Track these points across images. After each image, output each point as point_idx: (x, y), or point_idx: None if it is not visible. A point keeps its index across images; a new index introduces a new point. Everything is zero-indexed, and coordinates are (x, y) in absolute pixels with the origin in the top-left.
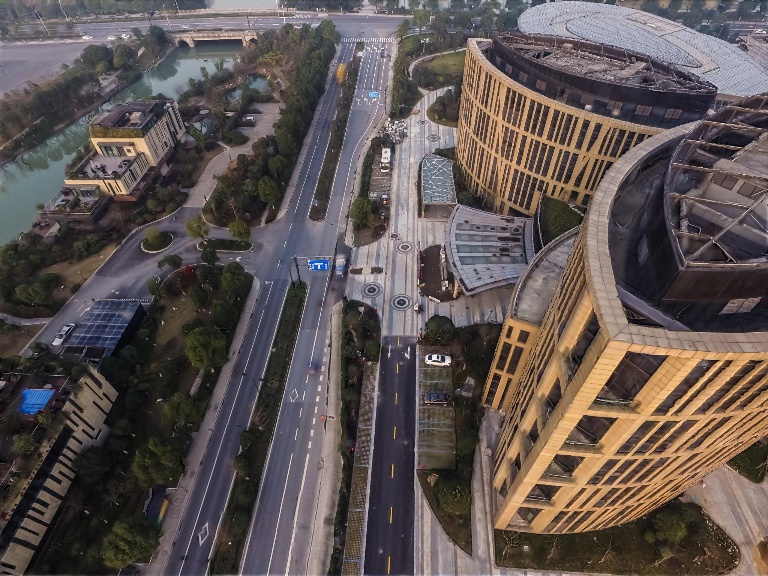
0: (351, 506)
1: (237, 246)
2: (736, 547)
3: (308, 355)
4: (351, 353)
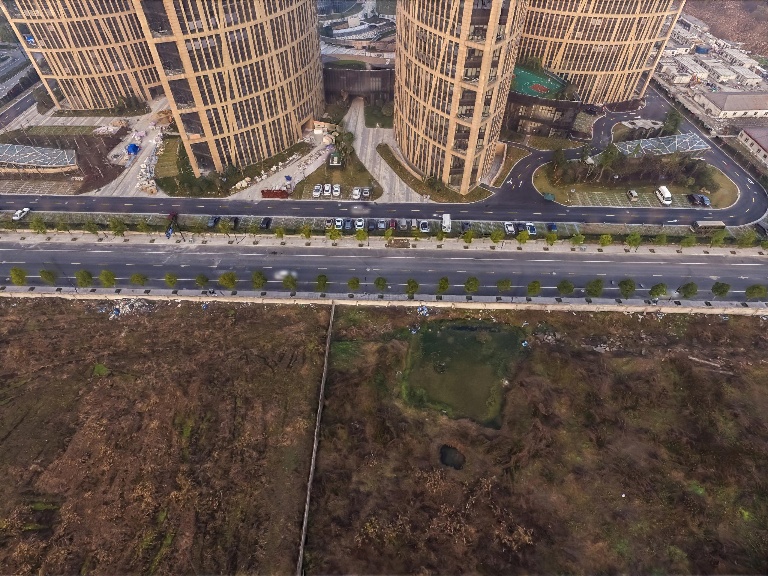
0: (3, 107)
1: (7, 47)
2: (150, 111)
3: (19, 78)
4: (33, 70)
